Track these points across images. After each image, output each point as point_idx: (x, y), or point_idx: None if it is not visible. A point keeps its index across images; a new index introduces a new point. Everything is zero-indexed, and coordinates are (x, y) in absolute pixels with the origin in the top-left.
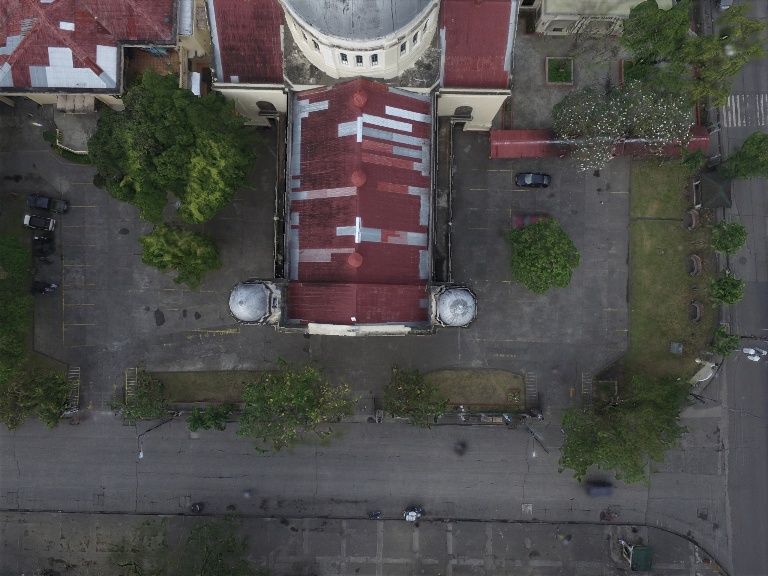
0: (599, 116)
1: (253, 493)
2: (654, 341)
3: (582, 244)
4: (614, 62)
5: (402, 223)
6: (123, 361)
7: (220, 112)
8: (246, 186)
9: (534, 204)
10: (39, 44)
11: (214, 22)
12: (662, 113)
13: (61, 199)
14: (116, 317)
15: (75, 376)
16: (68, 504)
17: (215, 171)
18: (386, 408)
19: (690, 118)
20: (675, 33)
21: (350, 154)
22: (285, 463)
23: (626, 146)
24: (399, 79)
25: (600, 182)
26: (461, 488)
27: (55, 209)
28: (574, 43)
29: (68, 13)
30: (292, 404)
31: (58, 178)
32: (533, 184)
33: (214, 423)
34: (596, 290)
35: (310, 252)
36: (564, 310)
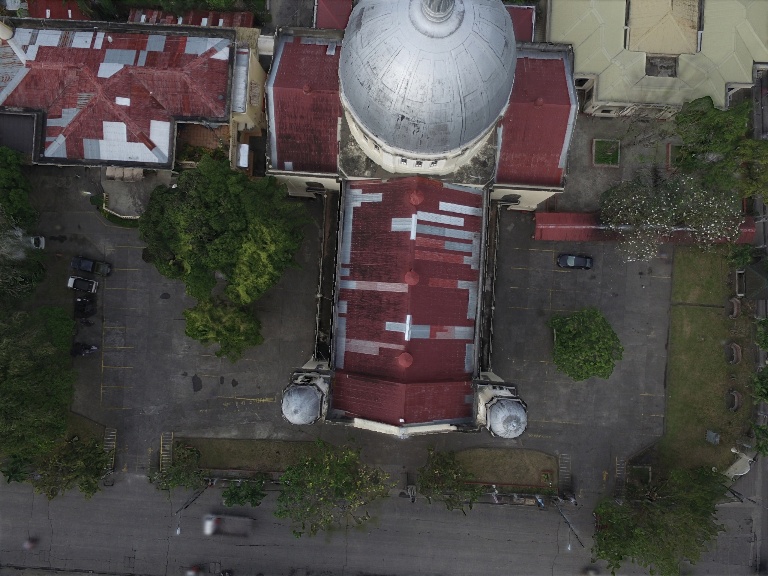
0: (649, 211)
1: (283, 562)
2: (690, 428)
3: (621, 327)
4: (661, 146)
5: (450, 318)
6: (159, 425)
7: (272, 197)
8: (293, 266)
9: (575, 285)
10: (94, 118)
11: (272, 112)
12: (713, 212)
13: (104, 261)
14: (154, 381)
15: (111, 438)
16: (99, 565)
17: (265, 255)
18: (422, 491)
19: (740, 216)
20: None
21: (403, 251)
22: (316, 534)
23: (672, 234)
24: (454, 175)
25: (642, 266)
26: (490, 567)
27: (98, 272)
28: (622, 125)
29: (124, 88)
30: (330, 487)
31: (102, 240)
32: (575, 266)
33: (251, 501)
34: (634, 374)
35: (357, 343)
36: (601, 393)
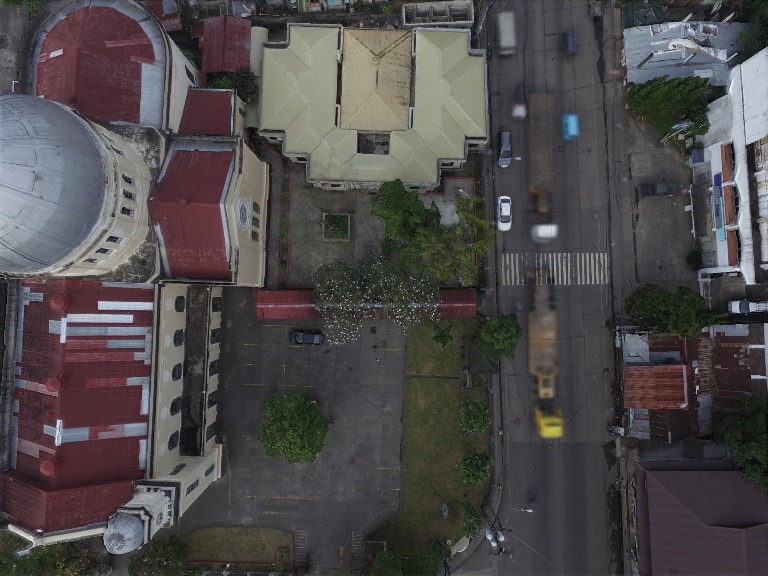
0: (341, 296)
1: None
2: (426, 501)
3: (356, 401)
4: None
5: (117, 416)
6: None
7: None
8: None
9: (309, 360)
10: None
11: None
12: (402, 296)
13: None
14: None
15: None
16: None
17: None
18: None
19: (434, 299)
20: (407, 222)
21: (55, 354)
22: None
23: None
24: (113, 274)
25: (376, 339)
26: None
27: None
28: (353, 198)
29: None
30: None
31: None
32: (304, 343)
33: None
34: (369, 448)
35: (25, 443)
36: (336, 468)
